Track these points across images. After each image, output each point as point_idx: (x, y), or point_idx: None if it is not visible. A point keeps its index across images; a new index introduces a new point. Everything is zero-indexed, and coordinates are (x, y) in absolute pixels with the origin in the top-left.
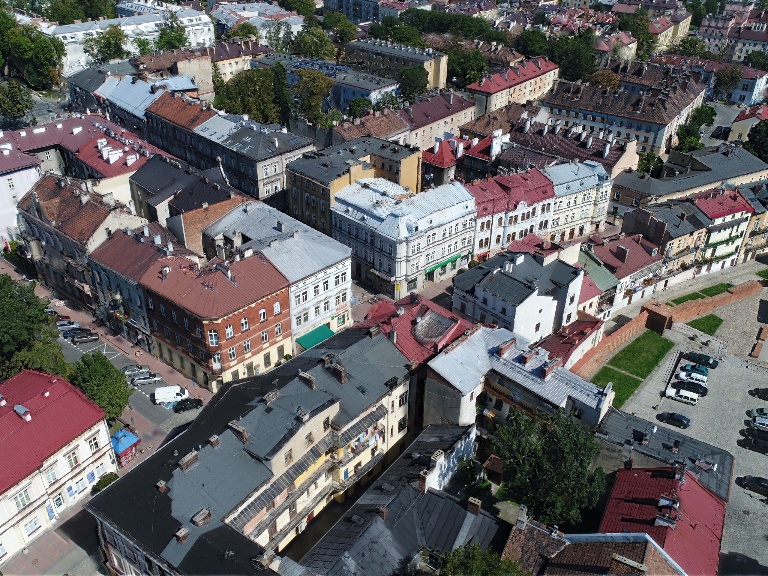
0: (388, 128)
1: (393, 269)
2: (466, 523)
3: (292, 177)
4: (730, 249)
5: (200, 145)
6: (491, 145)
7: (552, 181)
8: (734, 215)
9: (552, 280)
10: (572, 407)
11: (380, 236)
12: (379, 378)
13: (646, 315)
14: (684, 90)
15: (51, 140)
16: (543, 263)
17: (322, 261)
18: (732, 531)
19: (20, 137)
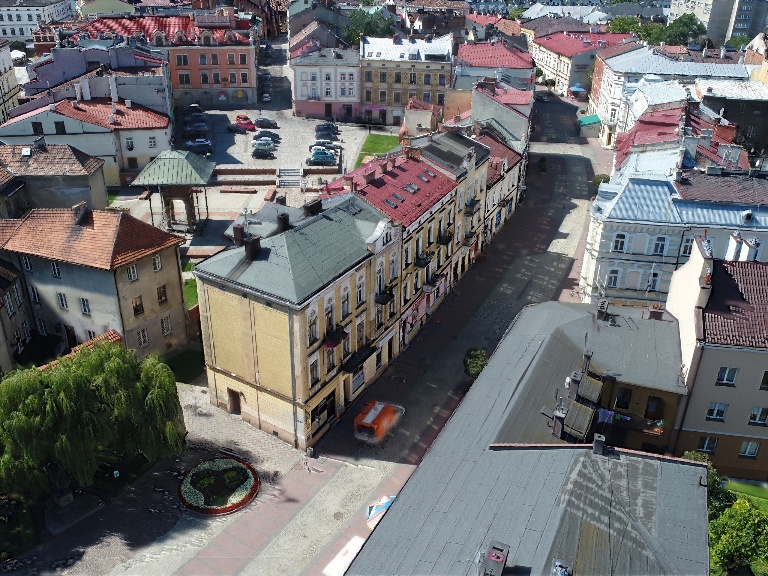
0: None
1: None
2: None
3: None
4: None
5: None
6: None
7: (634, 144)
8: None
9: None
10: None
11: None
12: None
13: None
14: None
15: None
16: None
17: None
18: (280, 115)
19: None
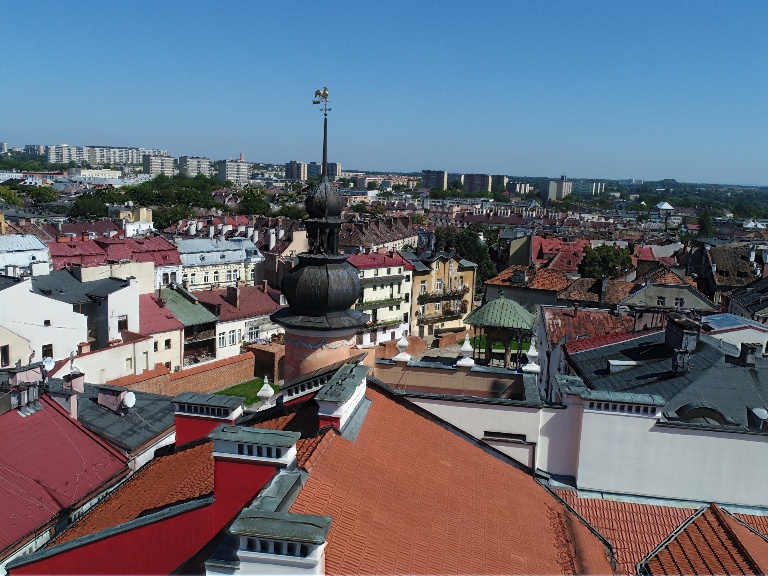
0: None
1: None
2: None
3: None
4: (396, 316)
5: None
6: (124, 230)
7: (176, 246)
8: (389, 270)
9: (88, 294)
10: None
11: None
12: None
13: (250, 356)
14: (390, 228)
15: None
16: (81, 277)
17: None
18: None
19: None
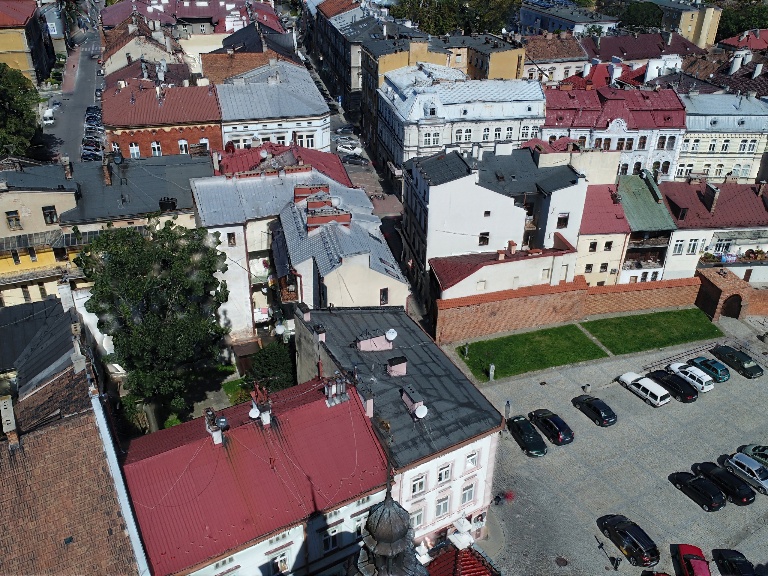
0: (556, 52)
1: (402, 161)
2: (64, 356)
3: (363, 56)
4: None
5: (332, 35)
6: (646, 67)
7: (685, 106)
8: None
9: (537, 184)
10: (319, 278)
11: (397, 117)
12: (159, 195)
13: (695, 283)
14: None
15: (208, 13)
16: (538, 162)
17: (280, 110)
18: None
19: (183, 6)
